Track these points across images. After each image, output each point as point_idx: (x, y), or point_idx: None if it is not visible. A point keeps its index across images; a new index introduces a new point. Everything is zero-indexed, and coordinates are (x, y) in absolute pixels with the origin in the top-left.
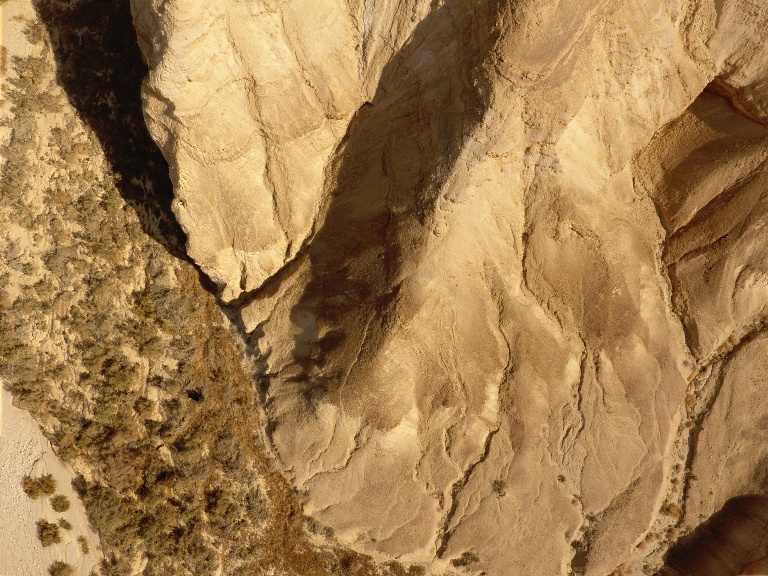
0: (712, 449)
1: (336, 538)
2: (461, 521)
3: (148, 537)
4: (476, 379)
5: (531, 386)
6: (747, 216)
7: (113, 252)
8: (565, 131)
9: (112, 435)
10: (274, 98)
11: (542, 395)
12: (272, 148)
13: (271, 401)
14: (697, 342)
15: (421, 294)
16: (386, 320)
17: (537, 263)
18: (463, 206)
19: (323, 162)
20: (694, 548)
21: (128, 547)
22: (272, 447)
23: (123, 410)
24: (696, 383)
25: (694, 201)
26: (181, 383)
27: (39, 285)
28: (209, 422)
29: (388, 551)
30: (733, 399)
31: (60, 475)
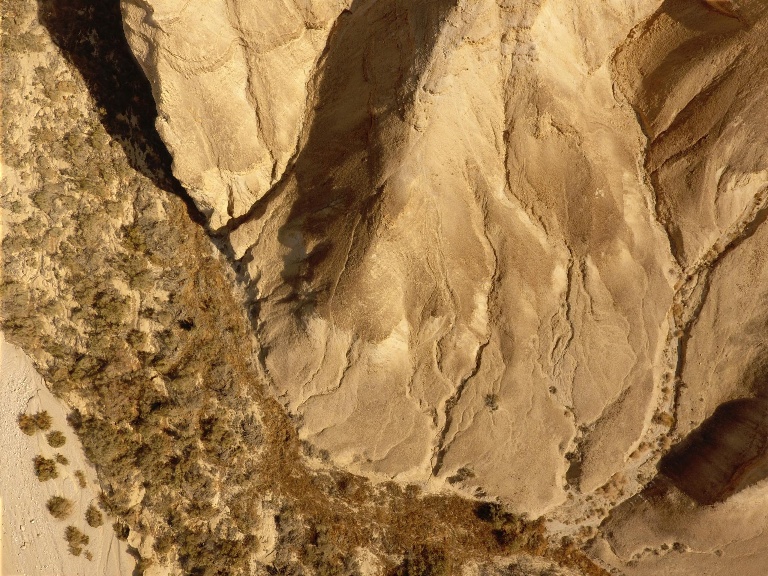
0: (701, 356)
1: (332, 461)
2: (455, 437)
3: (145, 465)
4: (464, 287)
5: (519, 294)
6: (725, 114)
7: (100, 187)
8: (539, 13)
9: (105, 367)
10: (252, 3)
11: (530, 305)
12: (253, 58)
13: (263, 326)
14: (682, 249)
15: (405, 192)
16: (371, 222)
17: (519, 164)
18: (442, 97)
19: (305, 77)
20: (687, 455)
21: (125, 478)
22: (265, 373)
23: (116, 343)
24: (683, 292)
25: (673, 103)
26: (173, 313)
27: (28, 221)
28: (202, 351)
29: (384, 470)
30: (720, 306)
31: (55, 411)
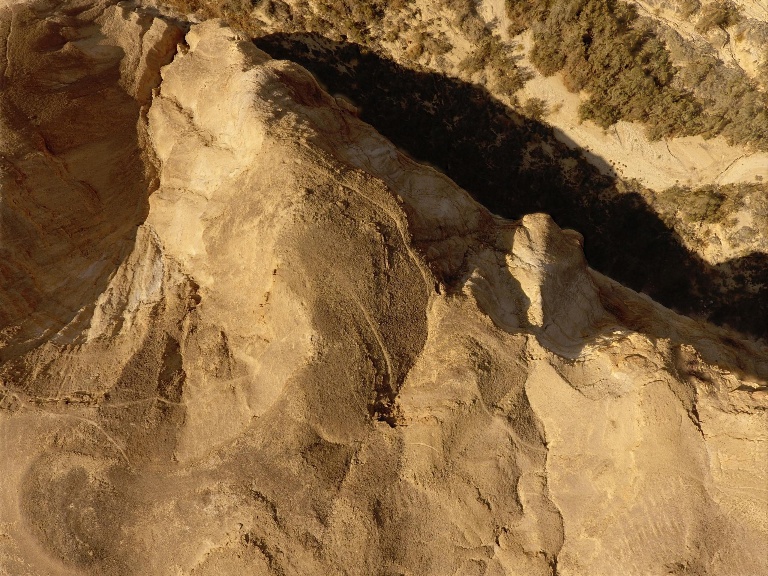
0: None
1: None
2: None
3: None
4: None
5: None
6: None
7: None
8: None
9: None
10: None
11: None
12: None
13: None
14: None
15: None
16: None
17: None
18: None
19: None
20: None
21: None
22: None
23: None
24: None
25: None
26: None
27: None
28: None
29: None
30: None
31: None
